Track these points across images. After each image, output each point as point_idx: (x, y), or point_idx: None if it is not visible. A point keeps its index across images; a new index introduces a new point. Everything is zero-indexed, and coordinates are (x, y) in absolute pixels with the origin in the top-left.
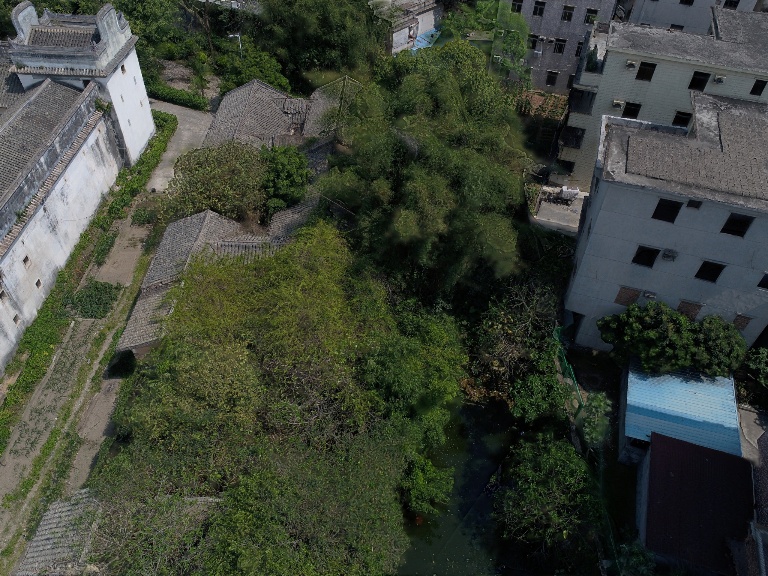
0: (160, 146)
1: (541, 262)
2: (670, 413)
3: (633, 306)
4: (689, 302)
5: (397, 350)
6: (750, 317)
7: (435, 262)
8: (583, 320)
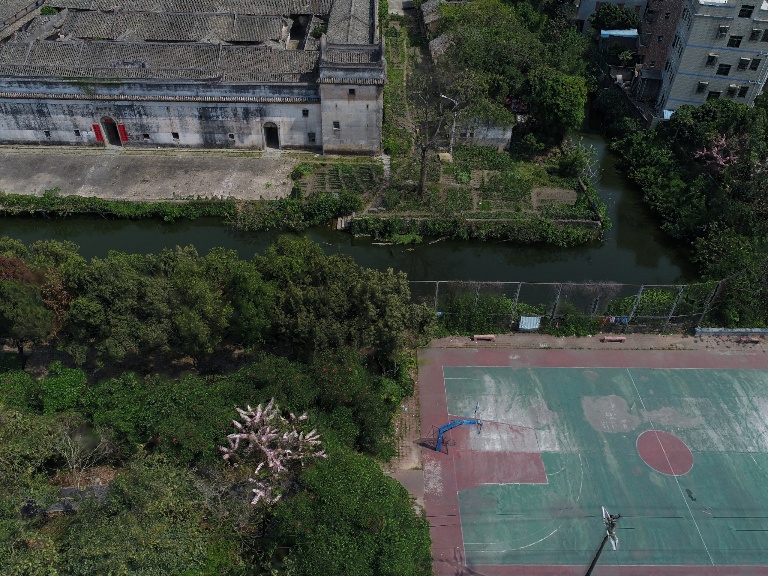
0: (386, 2)
1: None
2: (615, 34)
3: (601, 6)
4: (620, 4)
5: (528, 4)
6: (640, 6)
7: (530, 2)
8: (584, 23)
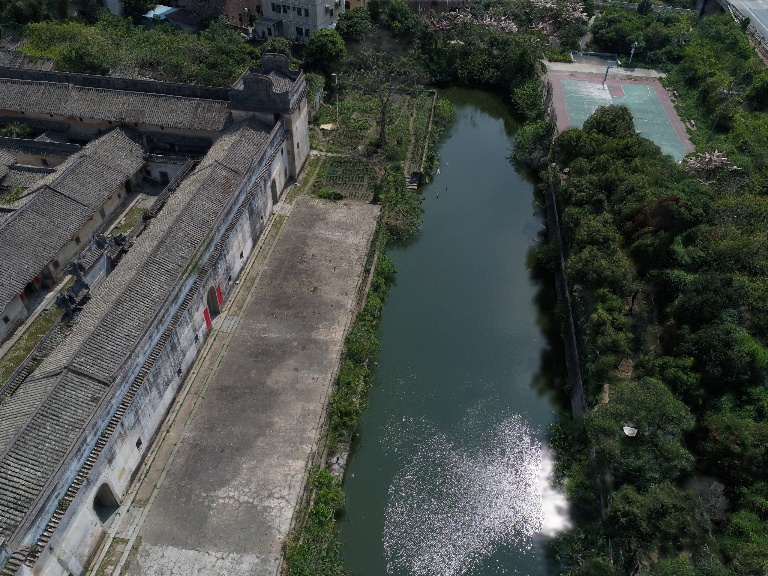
0: None
1: (90, 7)
2: None
3: None
4: None
5: None
6: None
7: None
8: None
